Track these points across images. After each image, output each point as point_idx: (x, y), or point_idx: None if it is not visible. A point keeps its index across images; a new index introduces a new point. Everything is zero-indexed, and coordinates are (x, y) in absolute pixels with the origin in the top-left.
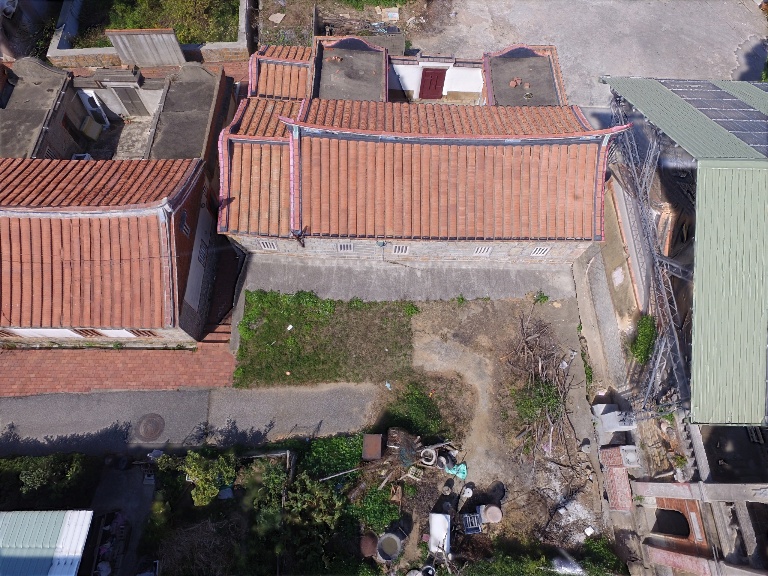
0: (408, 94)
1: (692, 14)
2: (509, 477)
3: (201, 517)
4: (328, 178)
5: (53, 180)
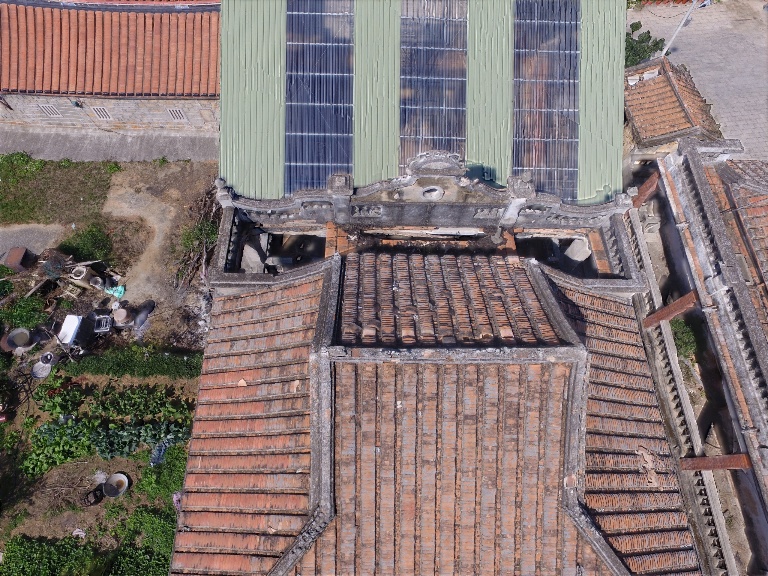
0: None
1: None
2: (162, 297)
3: None
4: (16, 40)
5: None
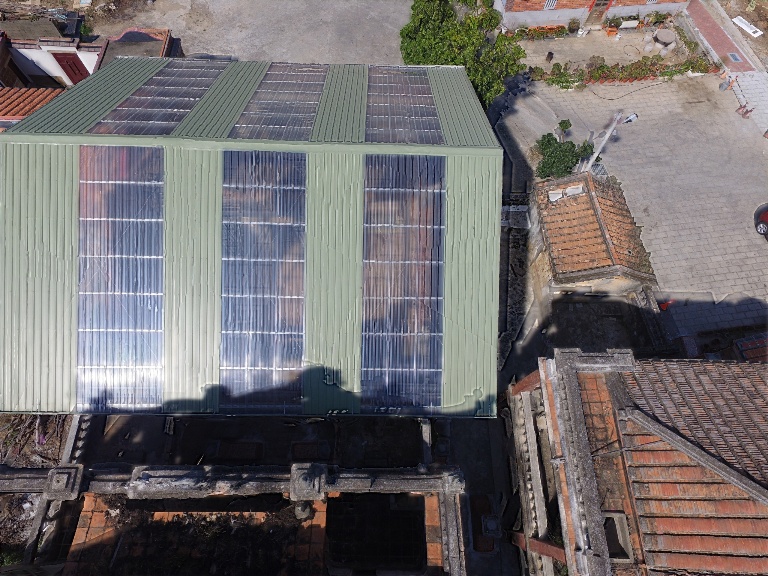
0: (59, 80)
1: (406, 2)
2: None
3: None
4: None
5: None
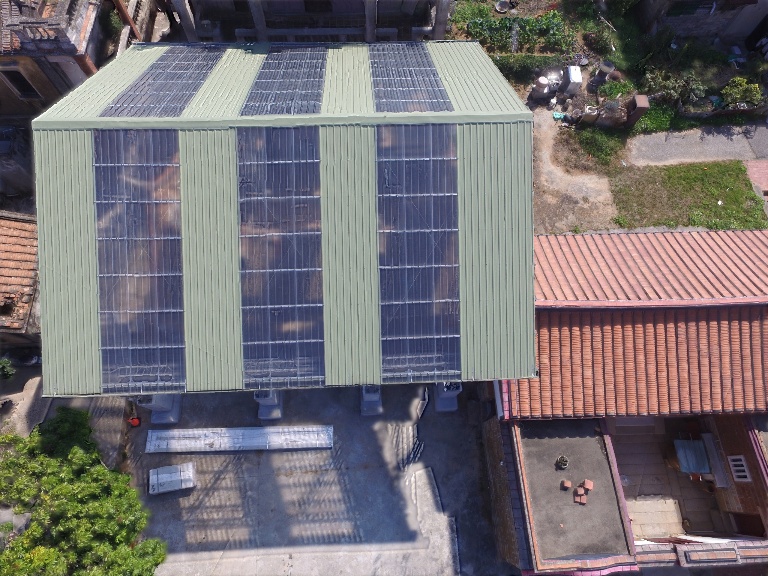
0: None
1: None
2: None
3: None
4: None
5: None
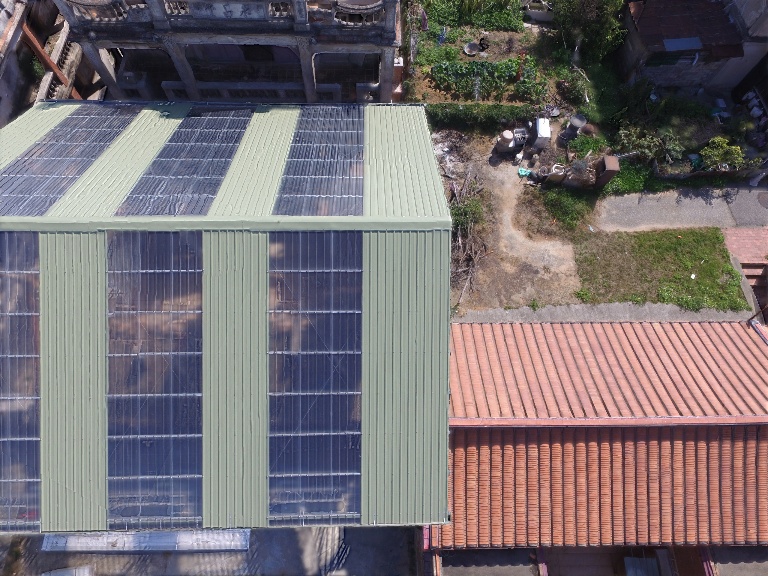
0: None
1: None
2: (485, 169)
3: (703, 146)
4: (761, 375)
5: None
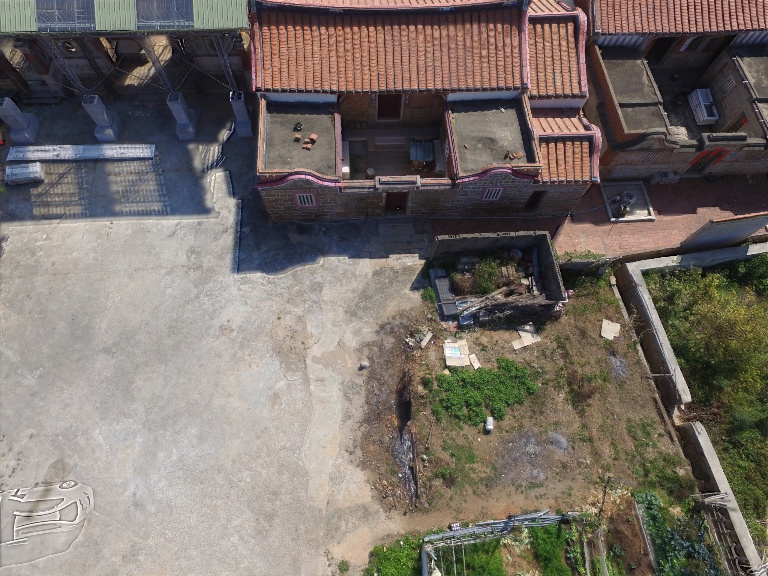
0: None
1: None
2: None
3: None
4: None
5: (694, 2)
